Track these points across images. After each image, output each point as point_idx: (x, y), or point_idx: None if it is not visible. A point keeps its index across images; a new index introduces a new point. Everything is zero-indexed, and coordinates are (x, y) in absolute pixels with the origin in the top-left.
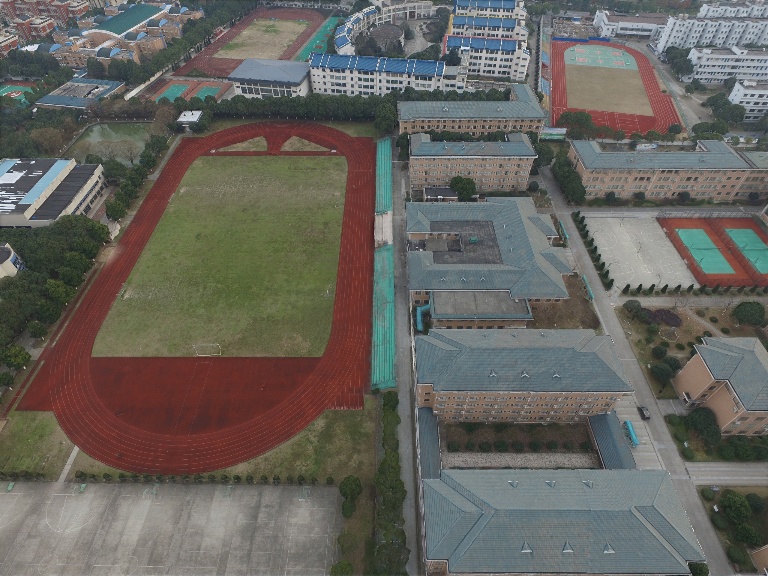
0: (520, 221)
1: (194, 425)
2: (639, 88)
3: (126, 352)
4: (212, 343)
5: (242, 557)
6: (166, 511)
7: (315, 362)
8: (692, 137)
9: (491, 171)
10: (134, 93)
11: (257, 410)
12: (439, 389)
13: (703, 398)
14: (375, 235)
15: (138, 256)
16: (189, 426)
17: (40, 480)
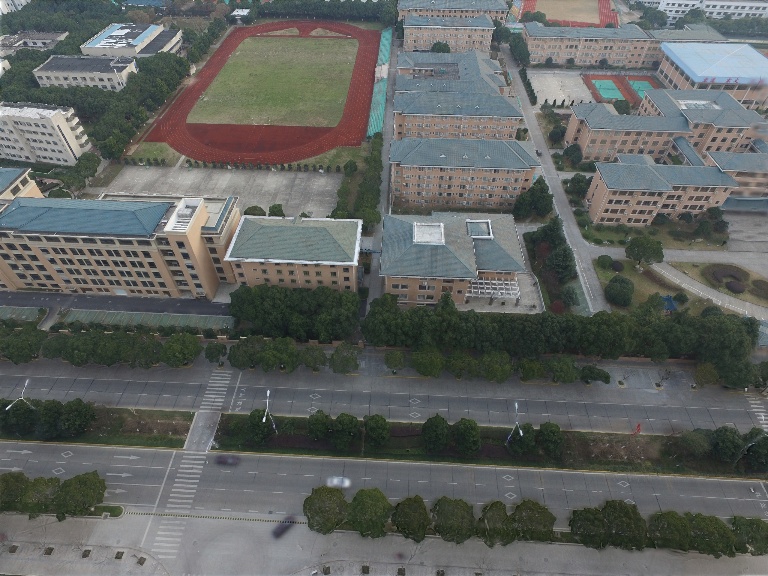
0: (475, 59)
1: (255, 150)
2: (594, 8)
3: (208, 122)
4: (264, 120)
5: (286, 194)
6: (241, 178)
7: (331, 129)
8: None
9: (462, 41)
10: None
11: (294, 146)
12: (406, 112)
13: (576, 142)
14: (375, 74)
15: (210, 82)
16: (252, 150)
17: (165, 165)
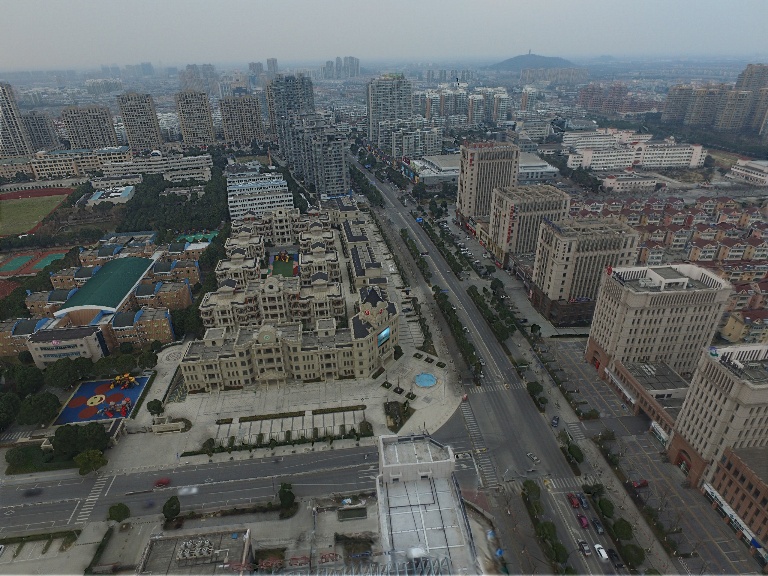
0: None
1: (31, 192)
2: None
3: None
4: None
5: None
6: None
7: None
8: None
9: None
10: None
11: None
12: None
13: None
14: None
15: None
16: None
17: None
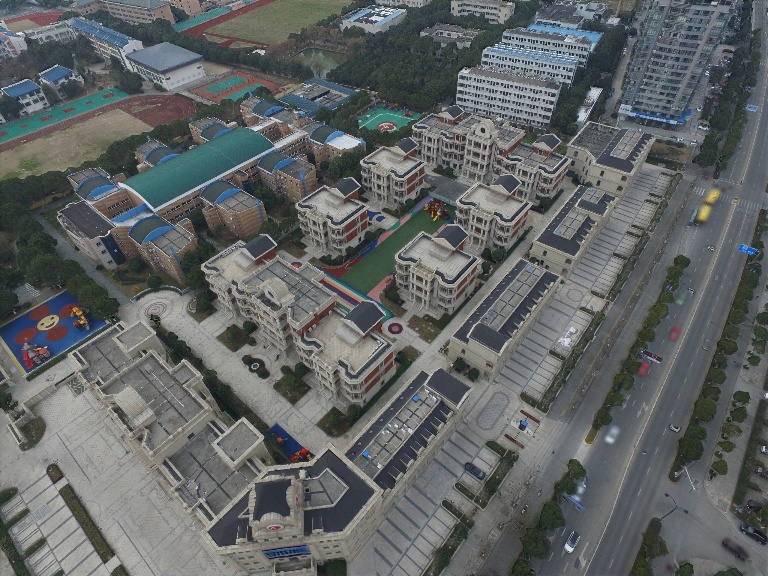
0: None
1: None
2: None
3: None
4: None
5: None
6: None
7: None
8: (57, 2)
9: None
10: (276, 98)
11: None
12: None
13: None
14: None
15: None
16: None
17: None
